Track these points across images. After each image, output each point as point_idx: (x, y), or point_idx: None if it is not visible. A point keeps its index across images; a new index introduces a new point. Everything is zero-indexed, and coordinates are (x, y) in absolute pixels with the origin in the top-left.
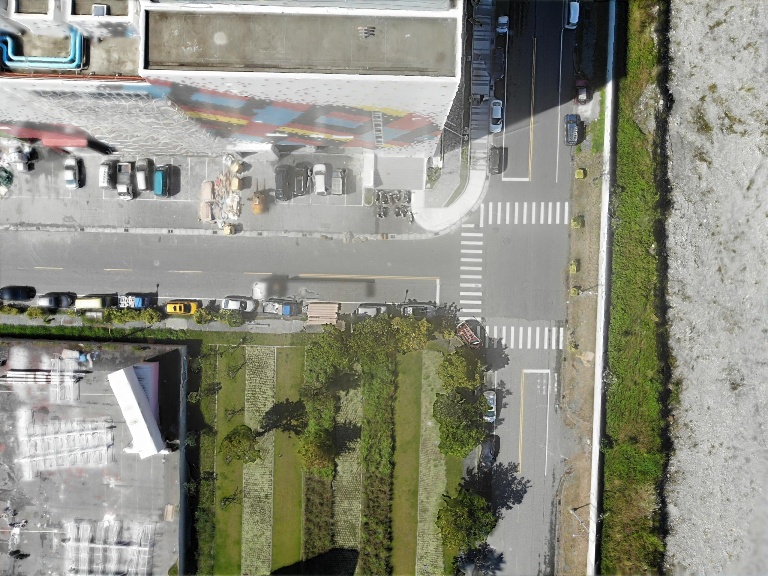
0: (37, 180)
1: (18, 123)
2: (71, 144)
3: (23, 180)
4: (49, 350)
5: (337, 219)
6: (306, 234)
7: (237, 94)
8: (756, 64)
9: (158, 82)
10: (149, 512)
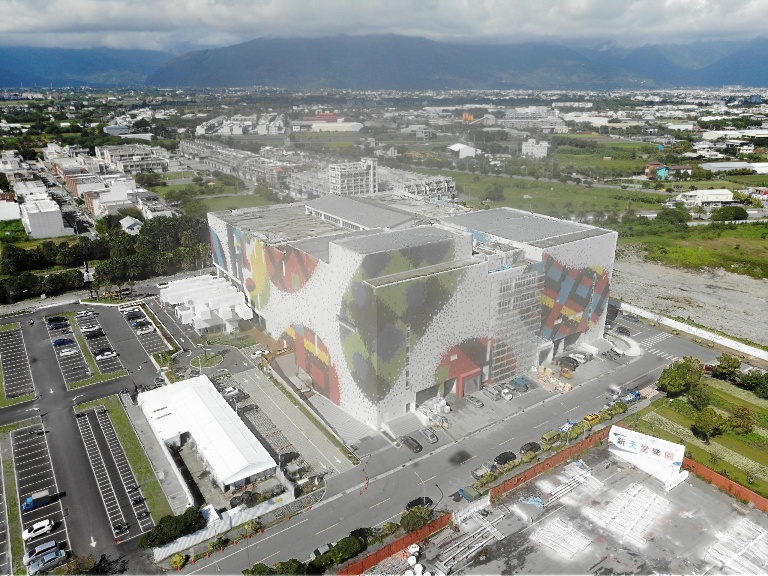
0: (458, 413)
1: (466, 344)
2: (475, 372)
3: (451, 416)
4: (556, 473)
5: (601, 368)
6: (598, 377)
7: (562, 264)
8: (647, 300)
9: (545, 257)
10: (731, 516)
